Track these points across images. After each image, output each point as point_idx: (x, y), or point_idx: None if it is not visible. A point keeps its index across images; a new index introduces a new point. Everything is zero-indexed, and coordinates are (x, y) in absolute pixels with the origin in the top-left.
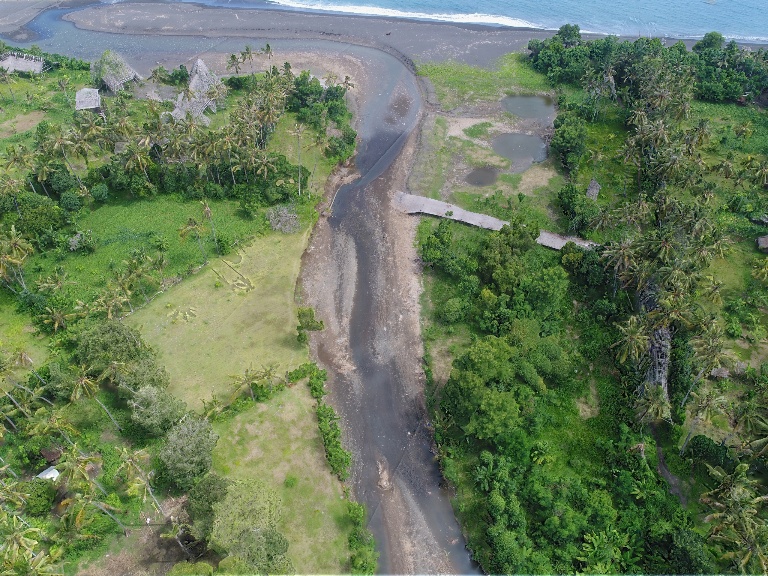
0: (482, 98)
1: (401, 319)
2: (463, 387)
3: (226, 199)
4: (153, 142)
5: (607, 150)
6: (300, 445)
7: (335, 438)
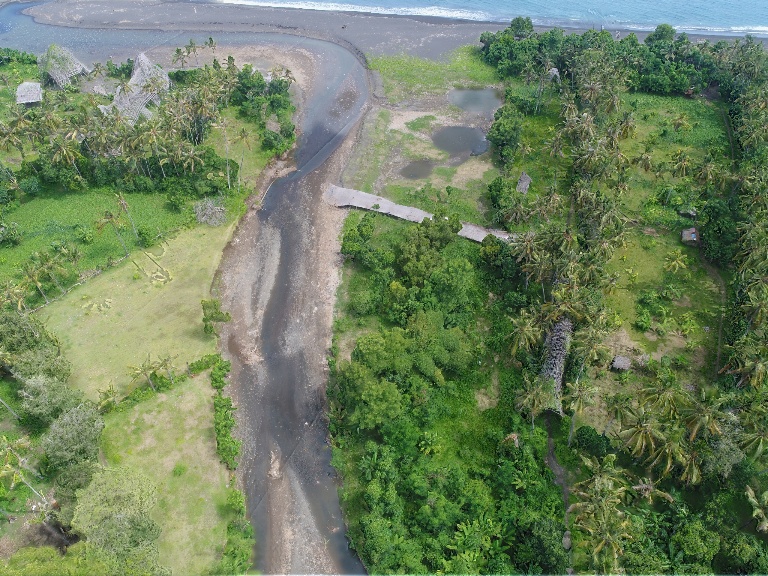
0: (429, 91)
1: (315, 311)
2: (349, 378)
3: (157, 192)
4: (89, 136)
5: None
6: (194, 435)
7: (226, 428)
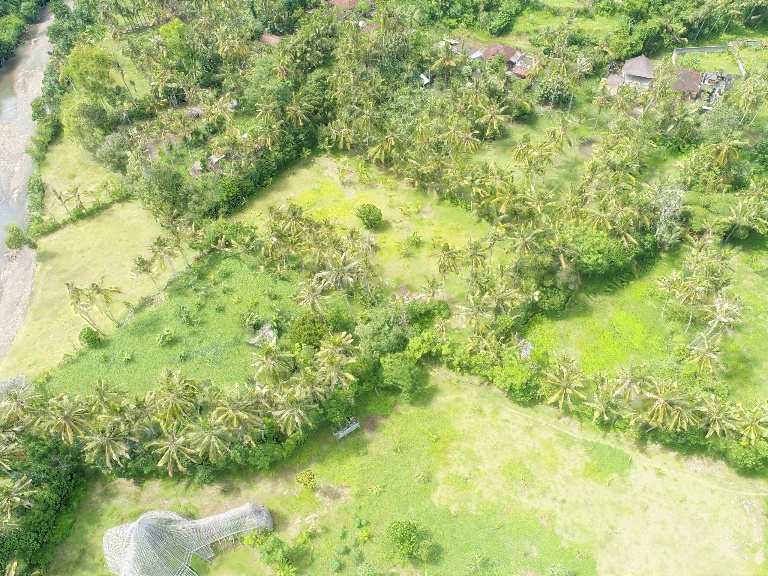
0: None
1: None
2: None
3: None
4: None
5: None
6: None
7: None
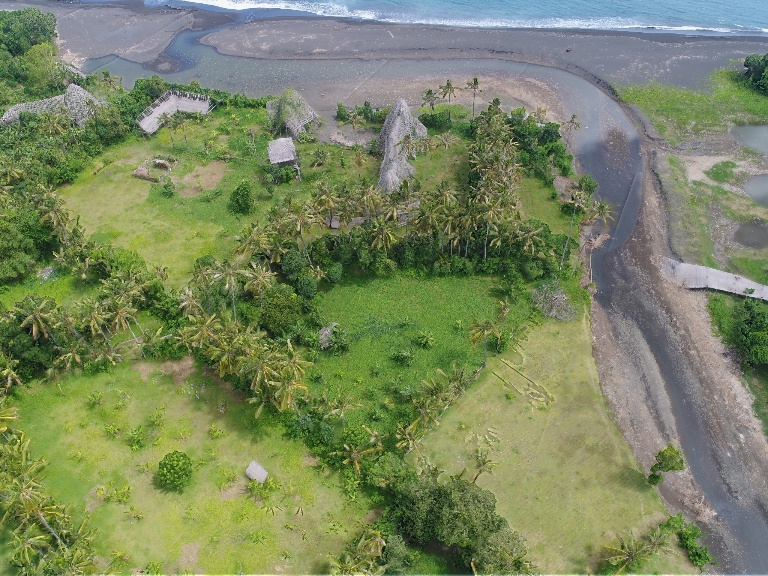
0: (709, 129)
1: (743, 440)
2: None
3: (473, 275)
4: None
5: None
6: None
7: None
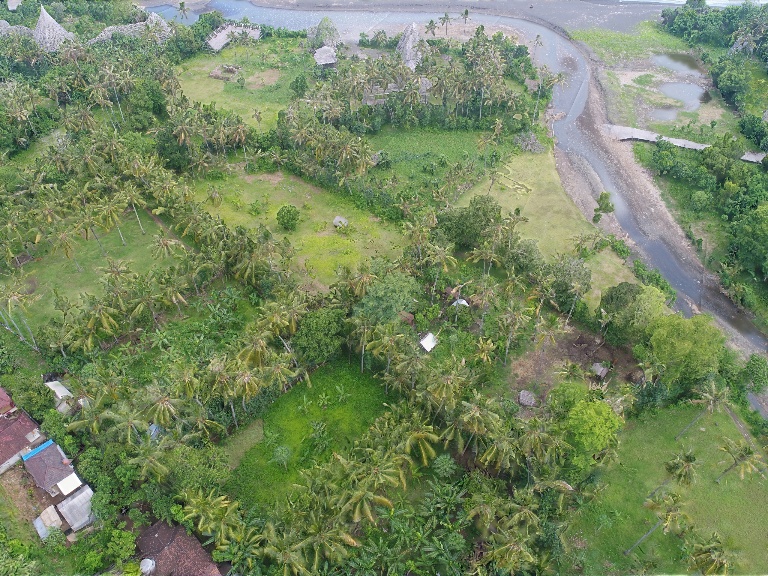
0: (636, 56)
1: (653, 211)
2: (759, 235)
3: (472, 130)
4: (397, 88)
5: (761, 92)
6: None
7: None
